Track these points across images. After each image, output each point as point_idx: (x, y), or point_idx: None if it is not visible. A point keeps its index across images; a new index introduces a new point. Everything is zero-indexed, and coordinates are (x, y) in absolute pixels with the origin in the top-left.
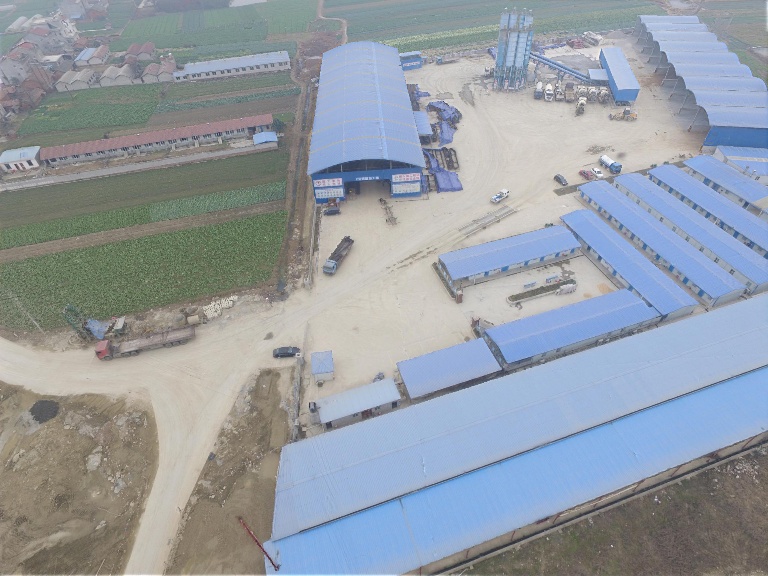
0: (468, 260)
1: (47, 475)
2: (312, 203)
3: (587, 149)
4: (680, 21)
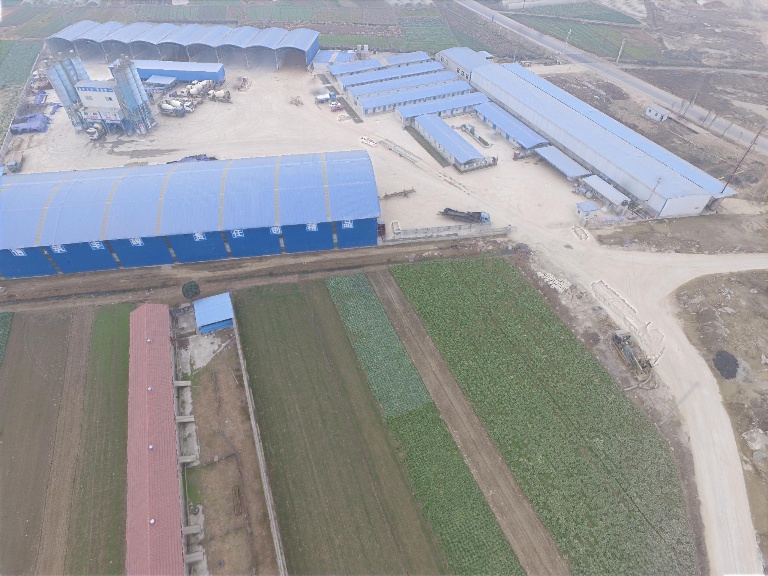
0: (466, 150)
1: (762, 327)
2: (374, 250)
3: (294, 105)
4: (88, 28)
